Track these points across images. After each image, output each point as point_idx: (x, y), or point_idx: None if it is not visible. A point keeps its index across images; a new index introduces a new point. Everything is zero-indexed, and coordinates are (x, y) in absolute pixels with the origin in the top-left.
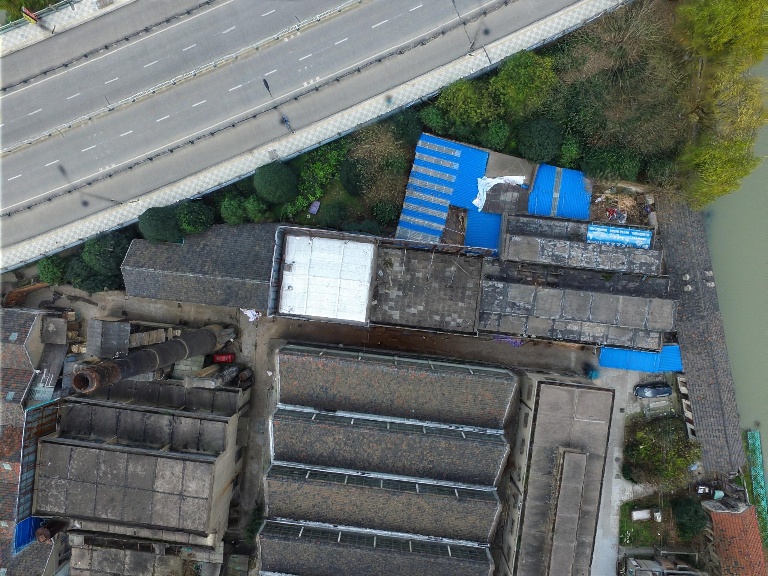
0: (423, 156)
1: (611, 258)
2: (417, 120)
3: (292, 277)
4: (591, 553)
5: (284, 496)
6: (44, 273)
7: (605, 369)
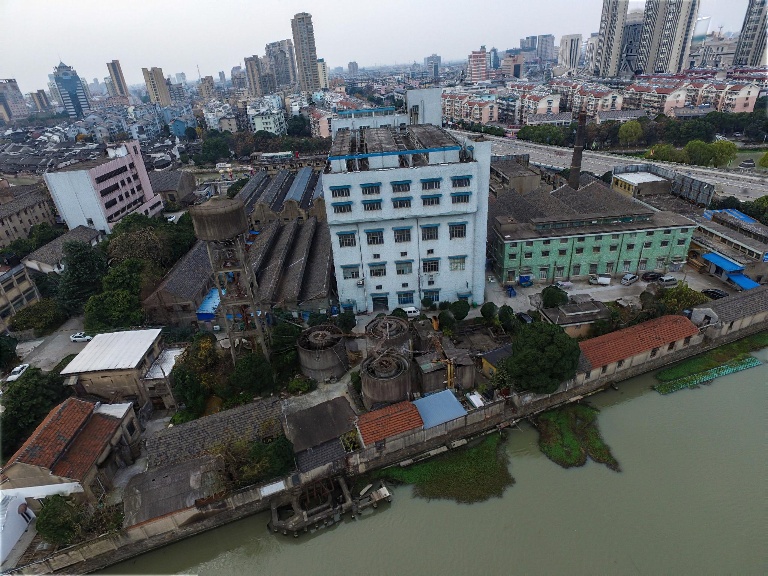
0: (725, 211)
1: (767, 233)
2: (738, 203)
3: (633, 174)
4: (600, 232)
5: (533, 194)
6: (565, 169)
7: (701, 281)
